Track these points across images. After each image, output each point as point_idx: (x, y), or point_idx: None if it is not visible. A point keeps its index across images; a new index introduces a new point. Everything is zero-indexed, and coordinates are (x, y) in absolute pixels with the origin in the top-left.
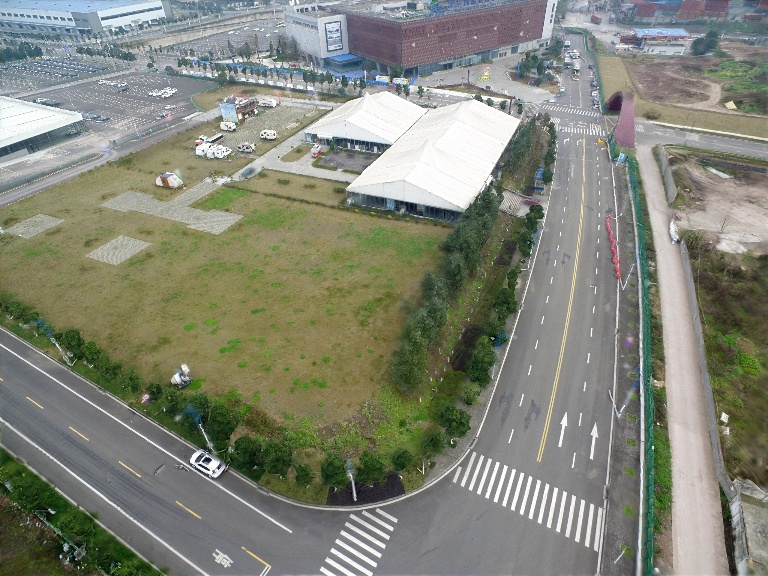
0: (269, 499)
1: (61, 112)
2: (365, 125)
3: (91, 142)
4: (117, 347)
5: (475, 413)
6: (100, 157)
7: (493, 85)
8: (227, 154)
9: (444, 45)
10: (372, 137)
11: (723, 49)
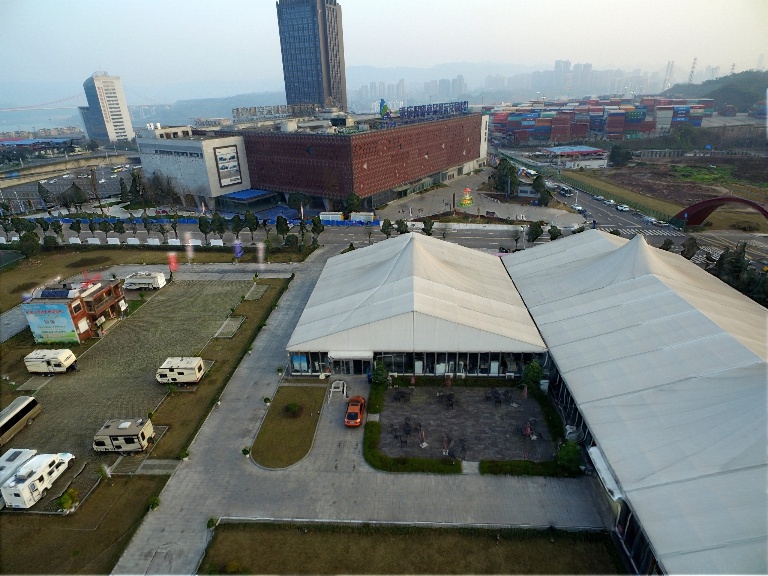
0: None
1: None
2: (457, 313)
3: None
4: None
5: None
6: None
7: (487, 210)
8: (55, 477)
9: (397, 166)
10: (488, 341)
11: (635, 160)
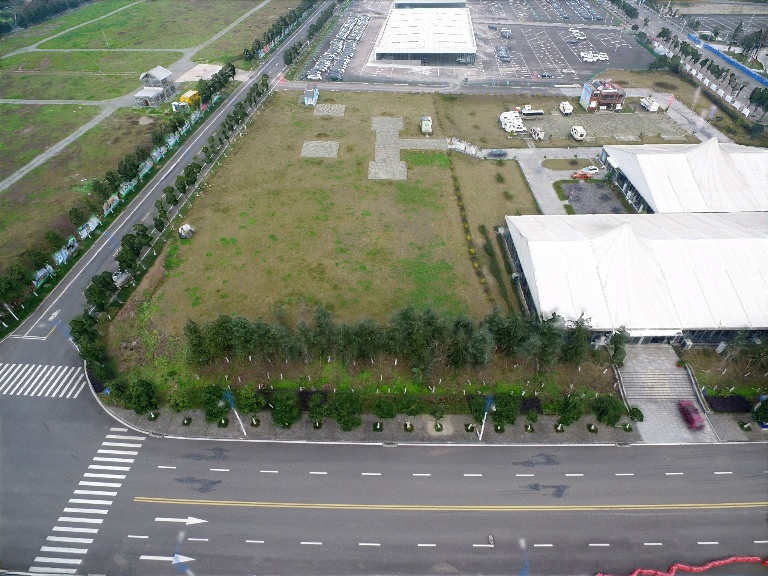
0: (96, 319)
1: (473, 42)
2: (655, 173)
3: (463, 74)
4: (215, 196)
5: (193, 428)
6: (443, 87)
7: None
8: (518, 131)
9: None
10: (645, 191)
11: None
